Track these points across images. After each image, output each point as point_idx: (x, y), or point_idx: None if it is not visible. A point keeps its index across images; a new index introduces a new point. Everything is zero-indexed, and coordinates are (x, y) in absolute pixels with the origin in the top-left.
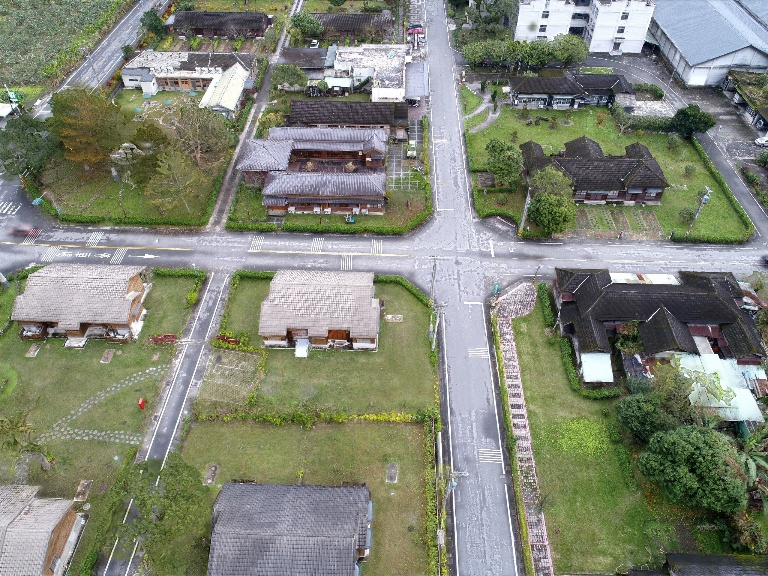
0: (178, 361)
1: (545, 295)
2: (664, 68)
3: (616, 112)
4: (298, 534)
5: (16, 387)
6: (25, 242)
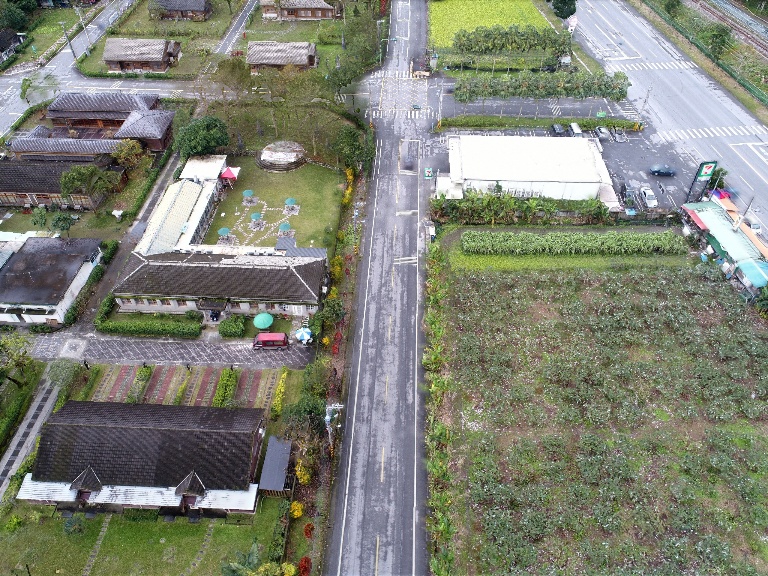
0: None
1: (4, 62)
2: None
3: None
4: None
5: (309, 42)
6: (345, 95)
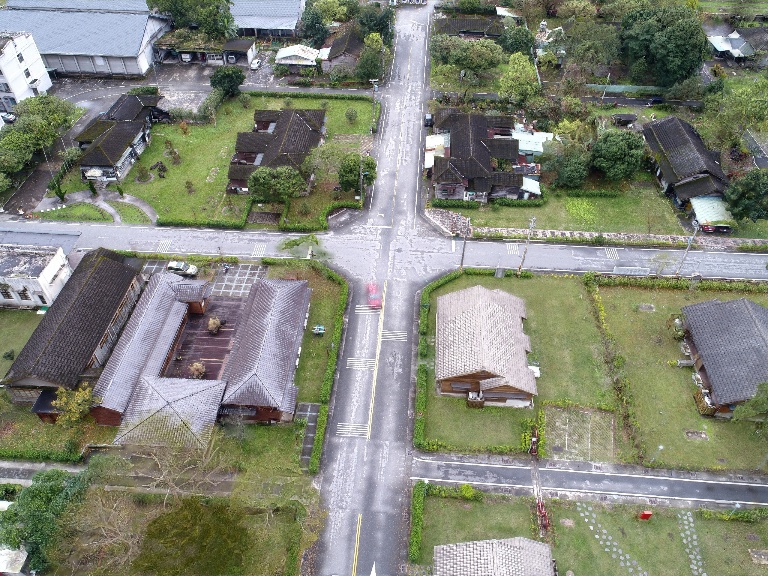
0: (570, 493)
1: (448, 201)
2: (96, 80)
3: (185, 114)
4: (760, 329)
5: None
6: None
